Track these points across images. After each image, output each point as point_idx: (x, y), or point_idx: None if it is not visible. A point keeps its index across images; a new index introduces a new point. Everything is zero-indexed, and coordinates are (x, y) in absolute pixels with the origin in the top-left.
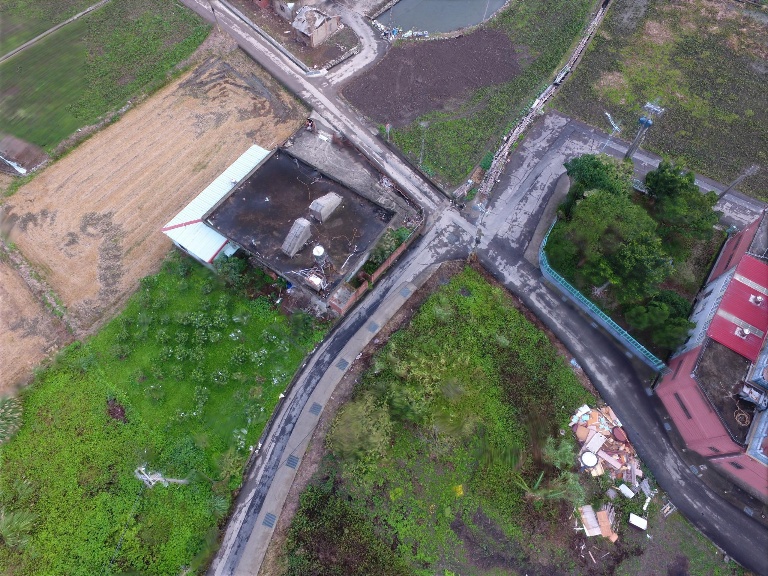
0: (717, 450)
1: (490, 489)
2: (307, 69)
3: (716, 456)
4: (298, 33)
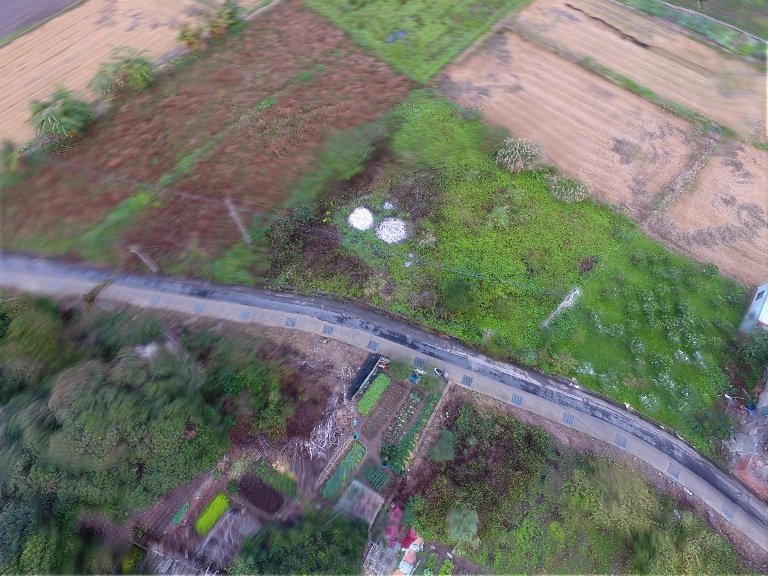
0: None
1: None
2: None
3: None
4: None
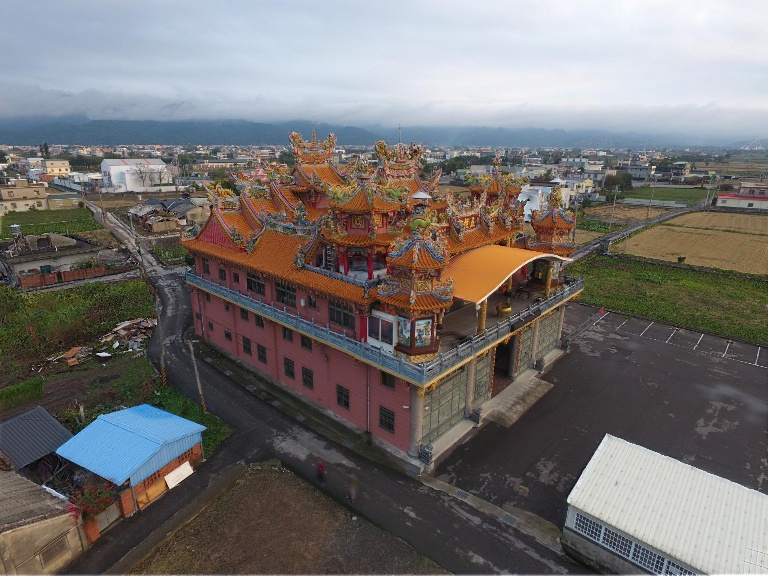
0: None
1: (7, 338)
2: (139, 236)
3: (202, 325)
4: (148, 227)
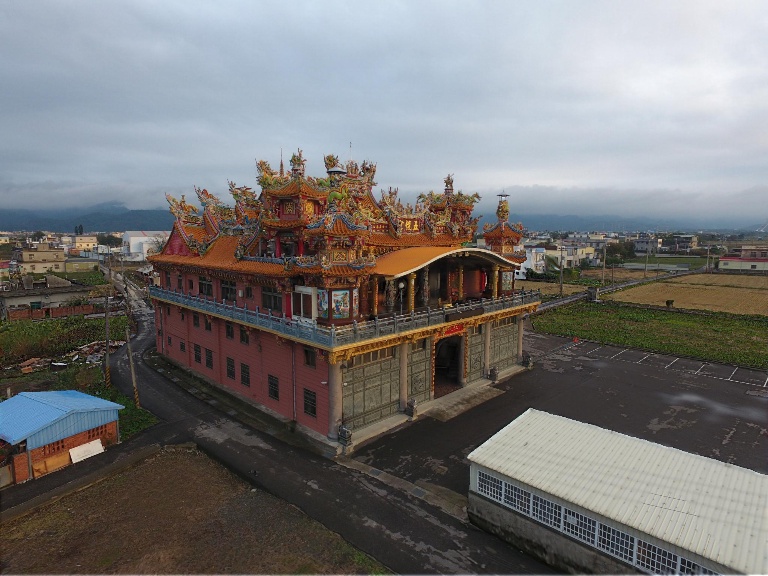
0: (160, 331)
1: None
2: None
3: None
4: (150, 281)
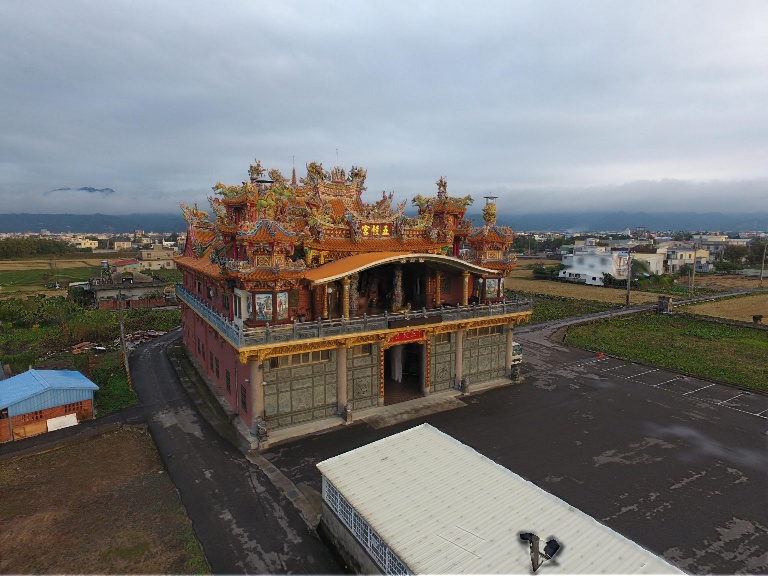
0: None
1: None
2: None
3: None
4: None
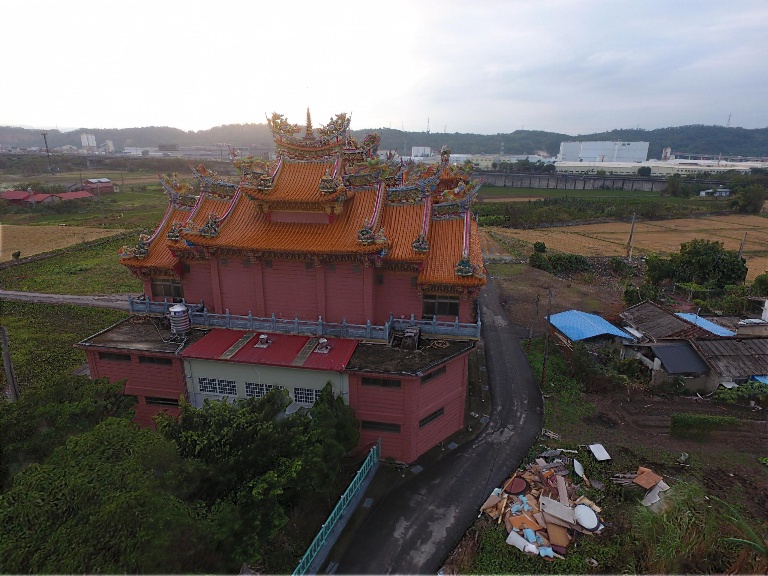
0: None
1: None
2: None
3: None
4: None
